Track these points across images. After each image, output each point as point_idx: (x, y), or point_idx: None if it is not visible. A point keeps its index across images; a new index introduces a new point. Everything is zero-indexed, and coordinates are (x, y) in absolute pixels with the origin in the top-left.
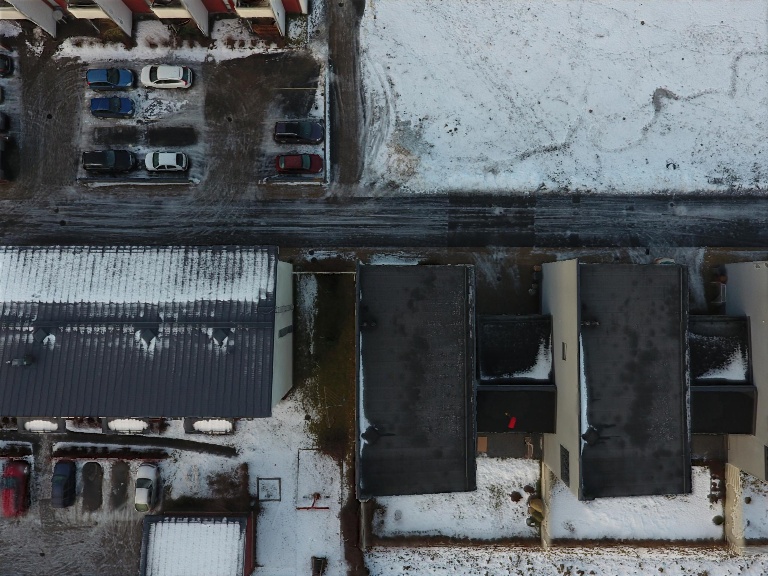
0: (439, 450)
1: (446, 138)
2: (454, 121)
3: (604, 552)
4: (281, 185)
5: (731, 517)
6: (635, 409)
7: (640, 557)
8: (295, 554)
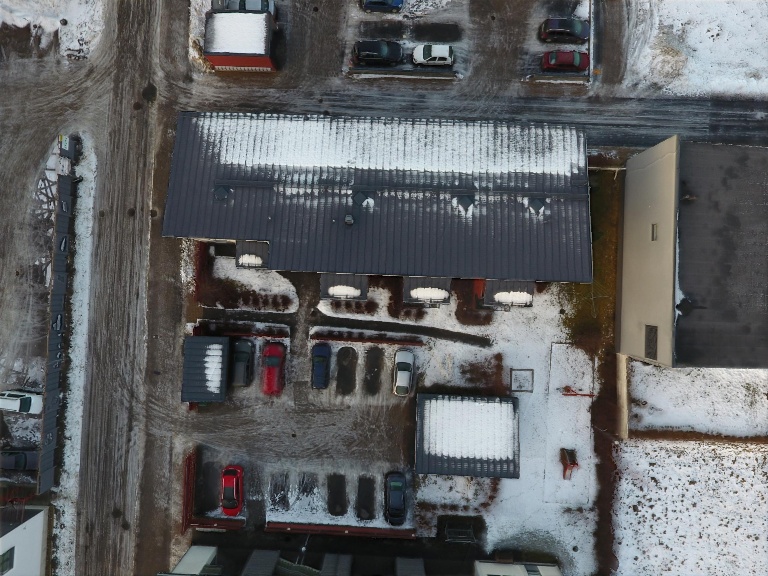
0: (747, 326)
1: (707, 43)
2: (716, 27)
3: None
4: (544, 83)
5: None
6: None
7: None
8: (545, 445)
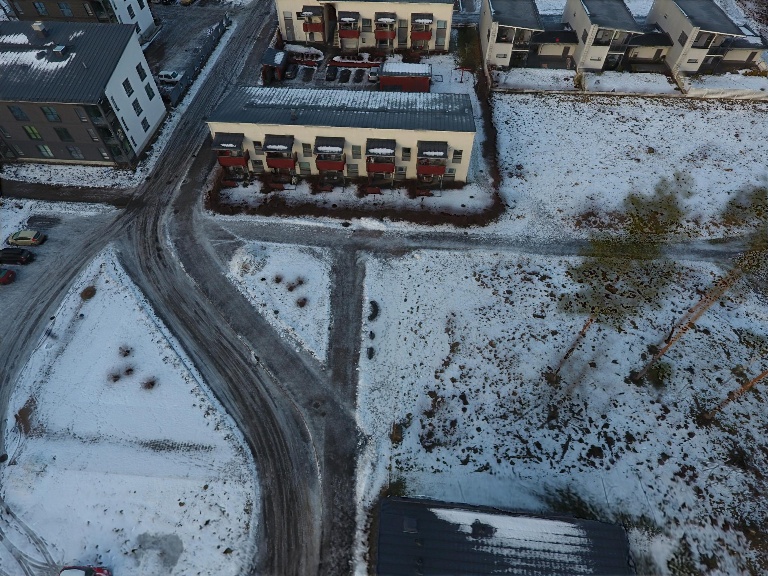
0: None
1: None
2: None
3: (621, 103)
4: None
5: (684, 89)
6: (609, 13)
7: (642, 107)
8: None
